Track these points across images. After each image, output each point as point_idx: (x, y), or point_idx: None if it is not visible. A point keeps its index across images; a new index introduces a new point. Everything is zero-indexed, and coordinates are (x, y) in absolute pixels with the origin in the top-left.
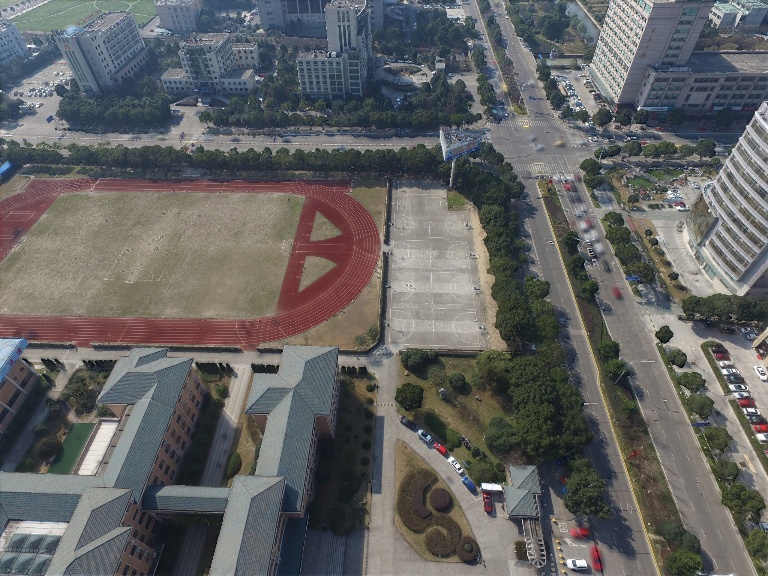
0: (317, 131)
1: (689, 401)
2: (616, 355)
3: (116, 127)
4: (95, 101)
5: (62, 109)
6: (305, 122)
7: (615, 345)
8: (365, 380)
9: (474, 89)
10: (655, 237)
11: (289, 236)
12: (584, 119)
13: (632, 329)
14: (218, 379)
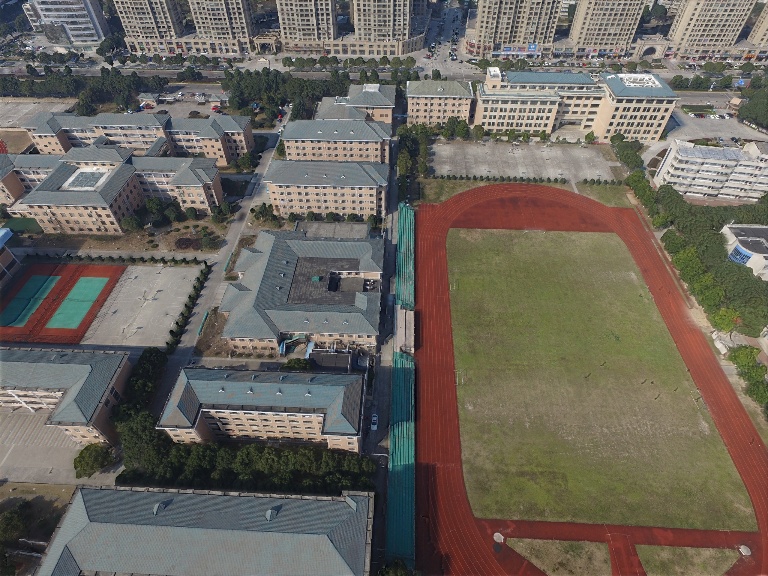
0: None
1: (140, 60)
2: None
3: None
4: None
5: None
6: None
7: None
8: None
9: None
10: None
11: None
12: None
13: (100, 72)
14: None
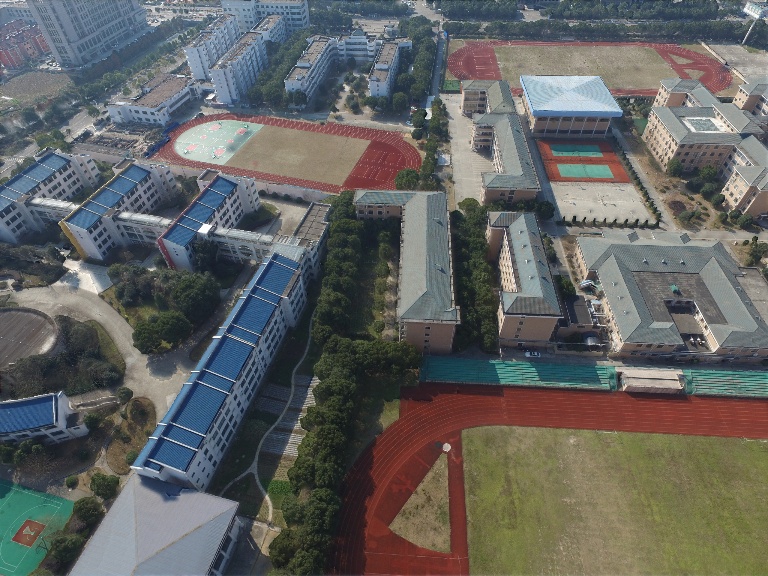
0: None
1: None
2: None
3: (484, 19)
4: (469, 2)
5: (451, 6)
6: (619, 14)
7: None
8: None
9: None
10: None
11: (663, 62)
12: None
13: None
14: None
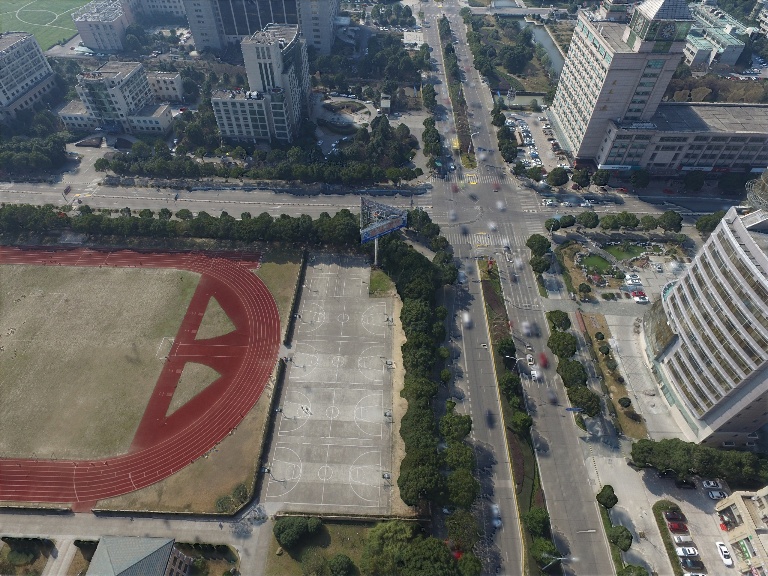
0: (233, 184)
1: None
2: (545, 532)
3: None
4: None
5: None
6: (218, 174)
7: (543, 519)
8: (224, 562)
9: (421, 133)
10: (607, 340)
11: (170, 332)
12: (537, 178)
13: (571, 479)
14: (29, 561)
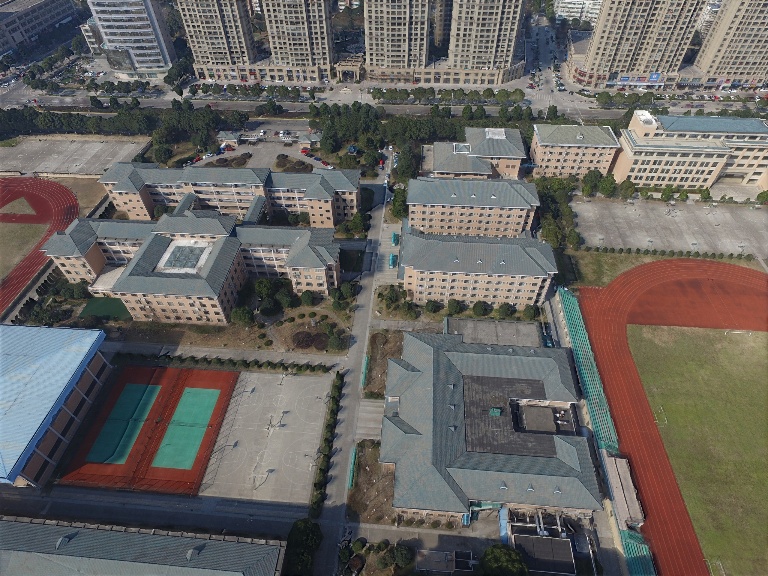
0: None
1: (214, 91)
2: None
3: None
4: None
5: None
6: None
7: None
8: None
9: None
10: None
11: None
12: None
13: (168, 103)
14: None
